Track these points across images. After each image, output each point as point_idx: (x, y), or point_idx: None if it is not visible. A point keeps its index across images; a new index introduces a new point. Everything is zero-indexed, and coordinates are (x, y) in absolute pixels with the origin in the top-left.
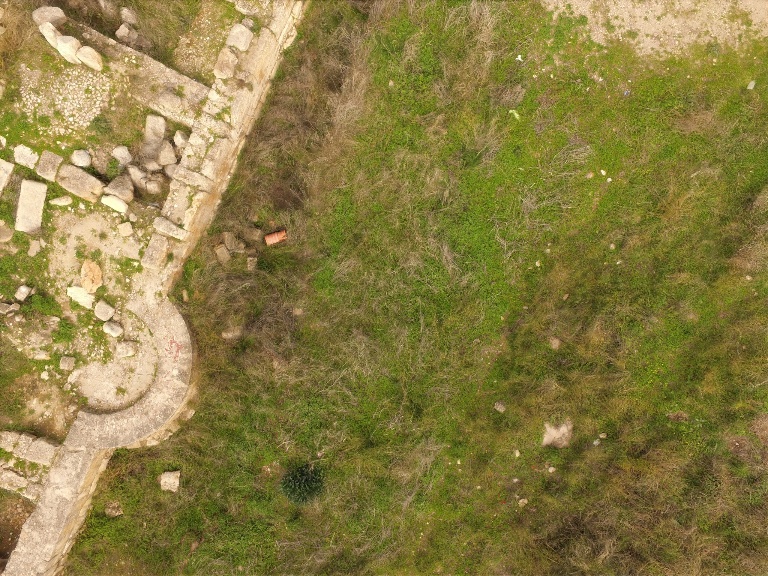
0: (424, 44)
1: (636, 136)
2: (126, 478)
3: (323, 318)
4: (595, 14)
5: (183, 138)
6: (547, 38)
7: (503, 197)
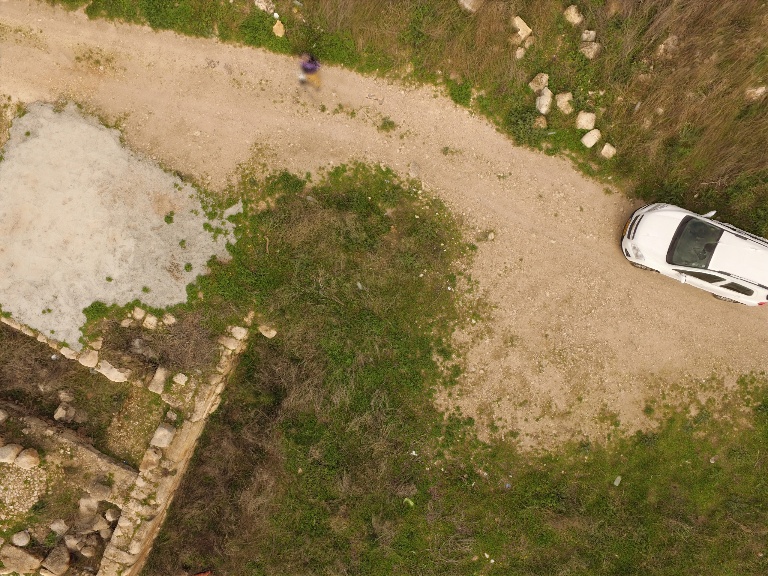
0: (329, 441)
1: (515, 527)
2: None
3: None
4: (481, 416)
5: (114, 517)
6: (438, 436)
7: (398, 574)
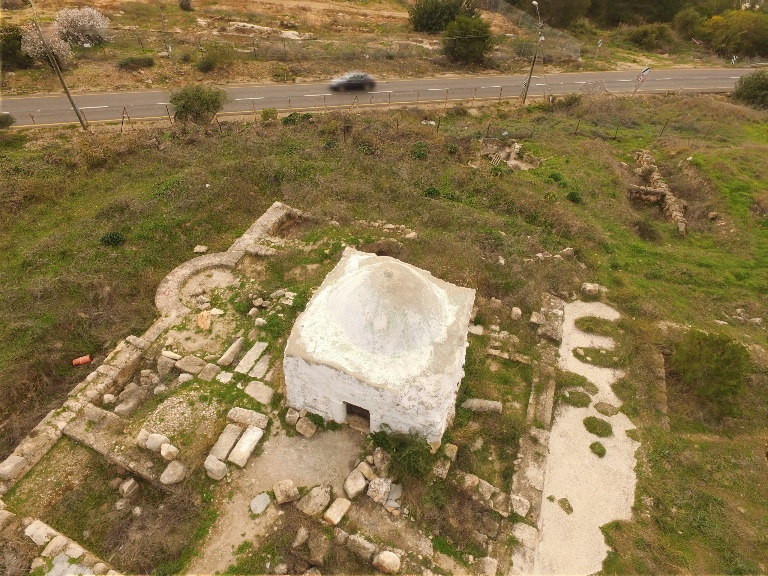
0: None
1: None
2: (222, 247)
3: (60, 305)
4: None
5: None
6: None
7: None
